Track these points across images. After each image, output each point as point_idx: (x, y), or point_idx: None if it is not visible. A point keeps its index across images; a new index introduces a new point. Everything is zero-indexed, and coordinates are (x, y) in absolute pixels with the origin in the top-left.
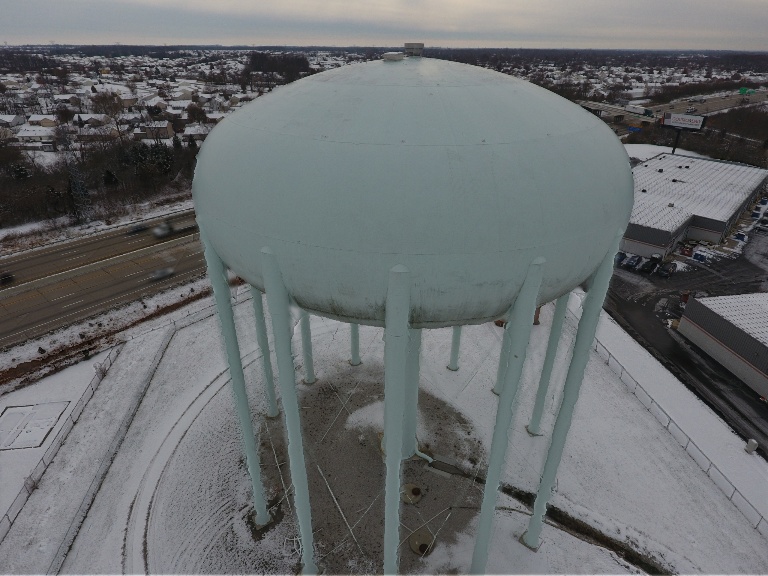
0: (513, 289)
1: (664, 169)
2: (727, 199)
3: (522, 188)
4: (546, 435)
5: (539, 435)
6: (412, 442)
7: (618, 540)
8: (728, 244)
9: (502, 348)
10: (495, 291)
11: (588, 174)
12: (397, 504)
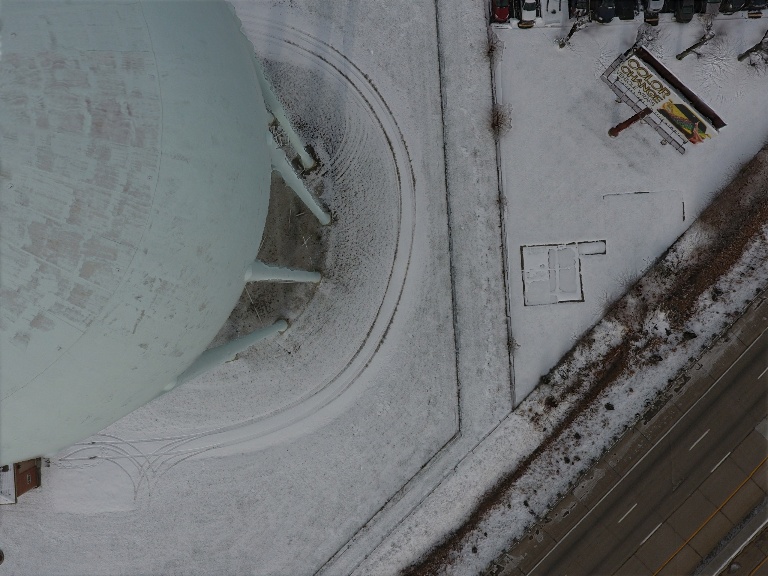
0: None
1: None
2: None
3: None
4: None
5: None
6: None
7: None
8: None
9: None
10: None
11: None
12: None
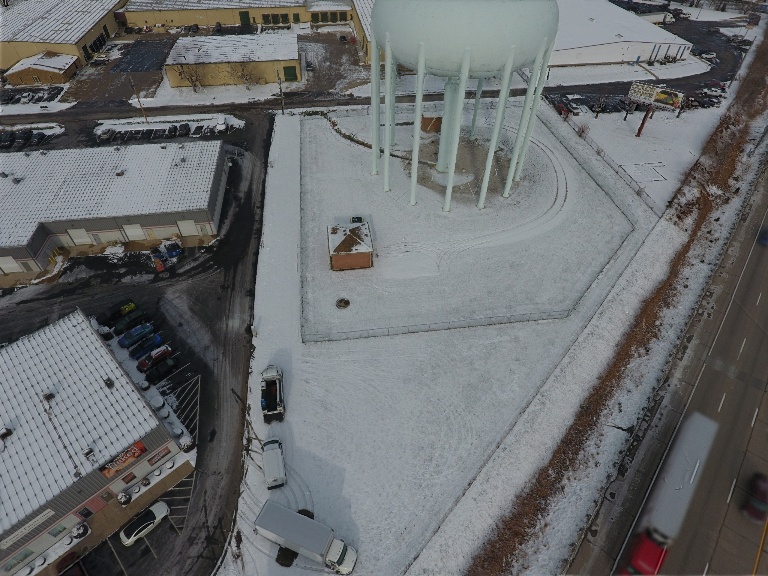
0: None
1: None
2: None
3: None
4: (369, 171)
5: None
6: None
7: None
8: None
9: None
10: None
11: None
12: None
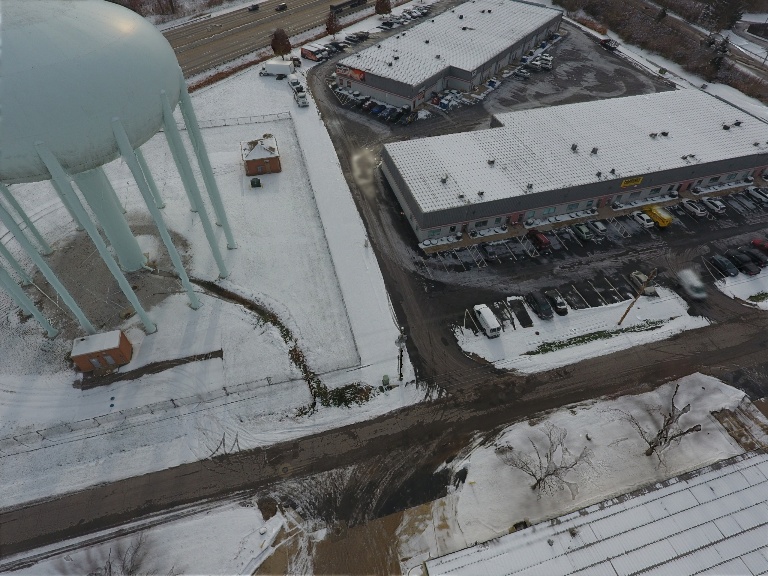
0: (35, 159)
1: (467, 14)
2: (493, 47)
3: (8, 104)
4: (239, 248)
5: (234, 249)
6: (139, 260)
7: (249, 300)
8: (478, 91)
9: (208, 192)
10: (22, 161)
11: (64, 90)
12: (56, 282)
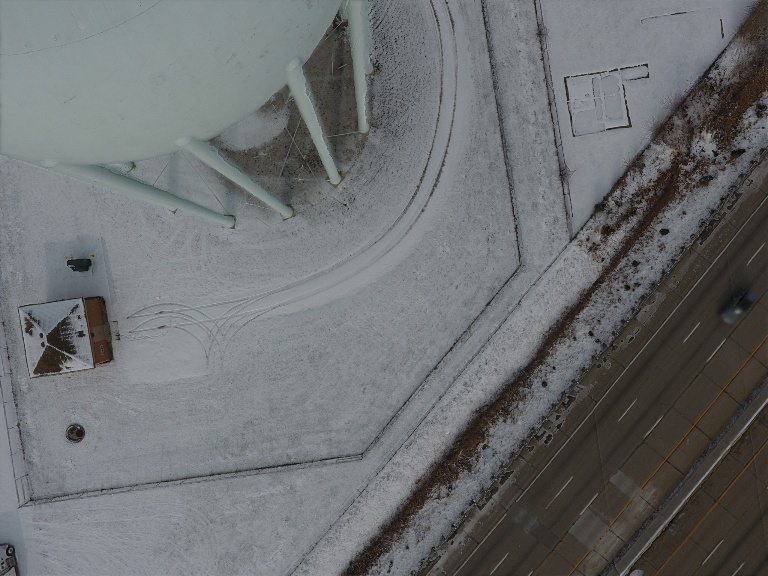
0: None
1: None
2: None
3: None
4: None
5: None
6: None
7: None
8: None
9: None
10: None
11: None
12: None
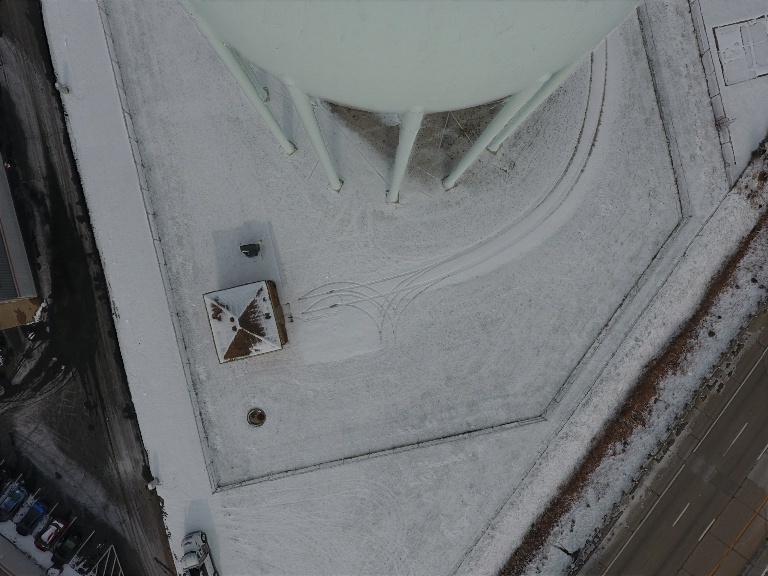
0: None
1: None
2: None
3: None
4: None
5: None
6: None
7: None
8: None
9: None
10: None
11: None
12: None
